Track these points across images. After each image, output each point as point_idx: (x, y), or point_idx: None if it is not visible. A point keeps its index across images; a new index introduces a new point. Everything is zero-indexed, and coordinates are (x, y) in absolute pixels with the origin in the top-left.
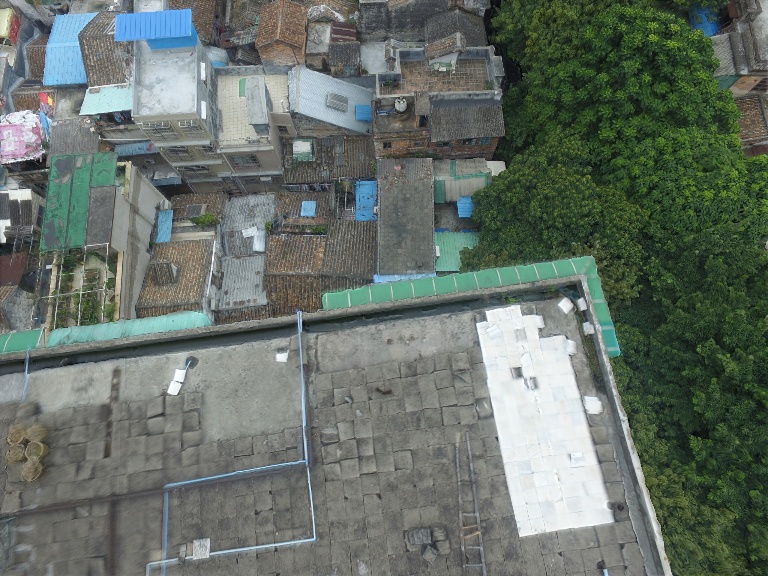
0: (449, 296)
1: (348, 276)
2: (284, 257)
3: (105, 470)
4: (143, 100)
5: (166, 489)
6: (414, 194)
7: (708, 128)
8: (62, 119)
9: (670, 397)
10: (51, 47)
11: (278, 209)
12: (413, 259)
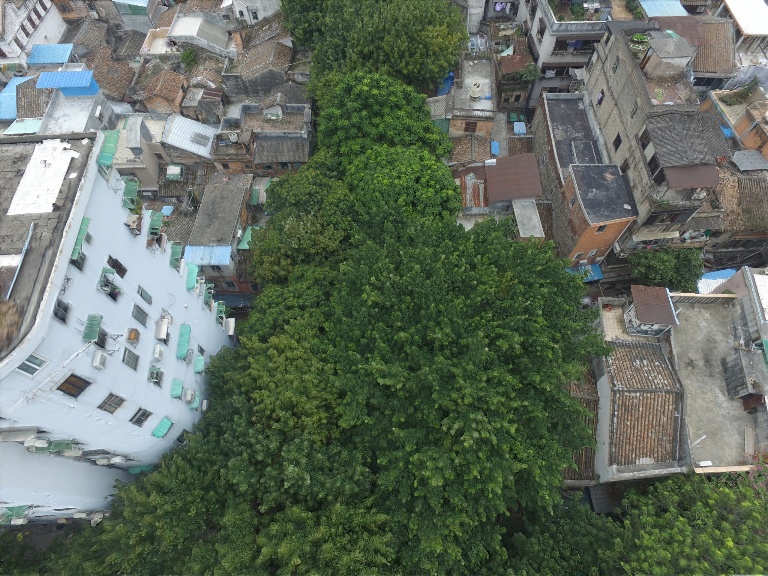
0: None
1: None
2: None
3: None
4: (50, 126)
5: None
6: (229, 195)
7: (410, 147)
8: None
9: None
10: (2, 95)
11: None
12: (216, 236)
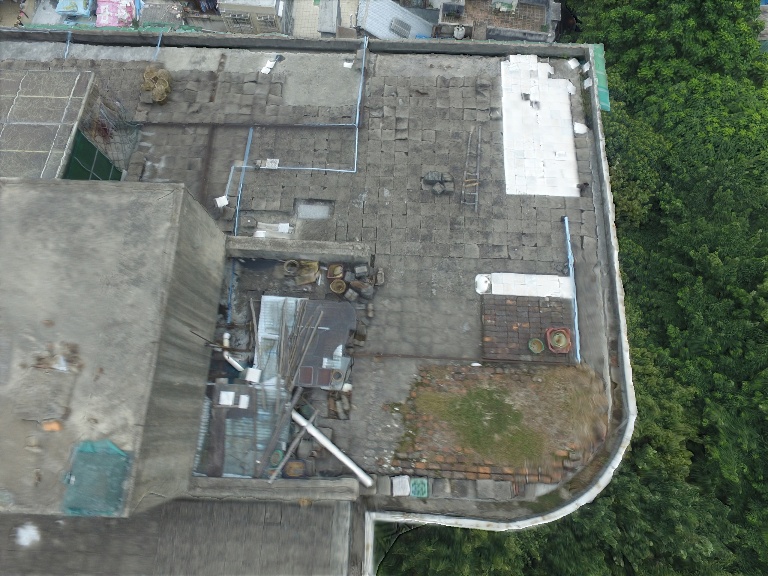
0: (483, 43)
1: None
2: None
3: (209, 110)
4: None
5: (252, 125)
6: None
7: (742, 80)
8: (153, 4)
9: None
10: None
11: None
12: None
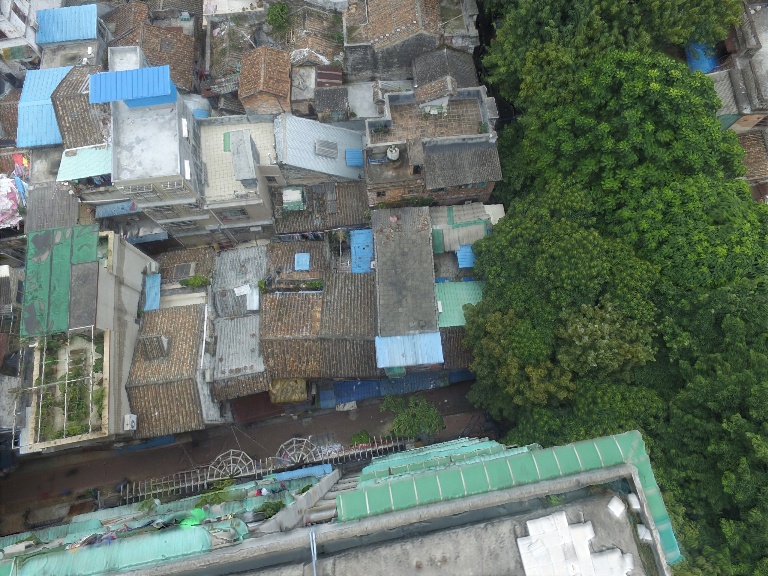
0: (483, 502)
1: (348, 338)
2: (280, 319)
3: None
4: (123, 162)
5: None
6: (412, 248)
7: (715, 175)
8: (39, 182)
9: (695, 470)
10: (23, 106)
11: (270, 263)
12: (415, 318)
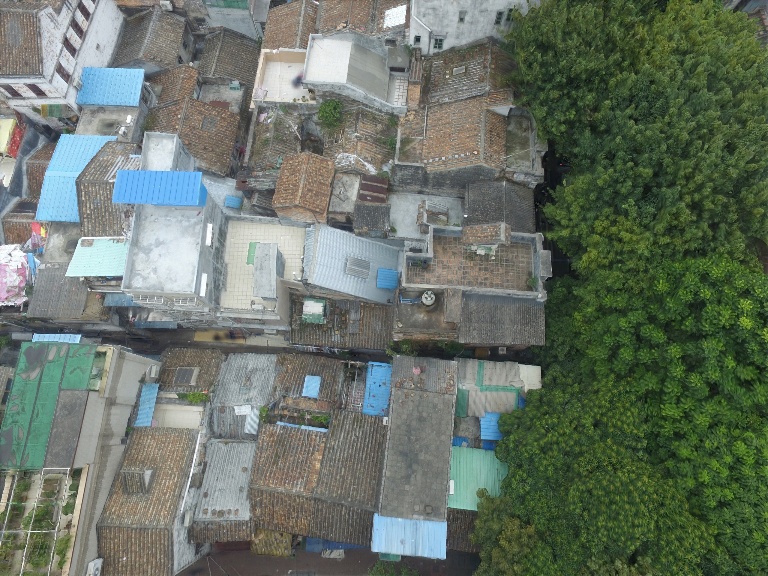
0: None
1: (345, 503)
2: (275, 462)
3: None
4: (138, 266)
5: None
6: (432, 413)
7: None
8: (52, 259)
9: None
10: (50, 175)
11: (278, 379)
12: (422, 501)
